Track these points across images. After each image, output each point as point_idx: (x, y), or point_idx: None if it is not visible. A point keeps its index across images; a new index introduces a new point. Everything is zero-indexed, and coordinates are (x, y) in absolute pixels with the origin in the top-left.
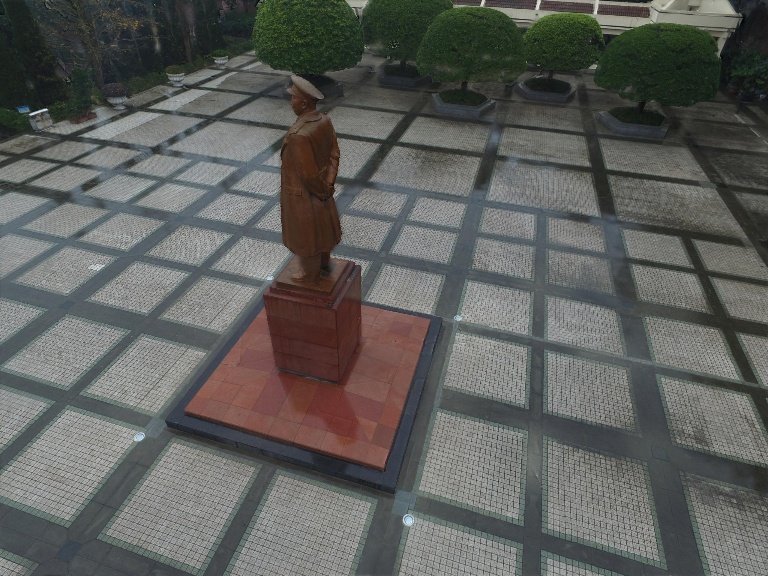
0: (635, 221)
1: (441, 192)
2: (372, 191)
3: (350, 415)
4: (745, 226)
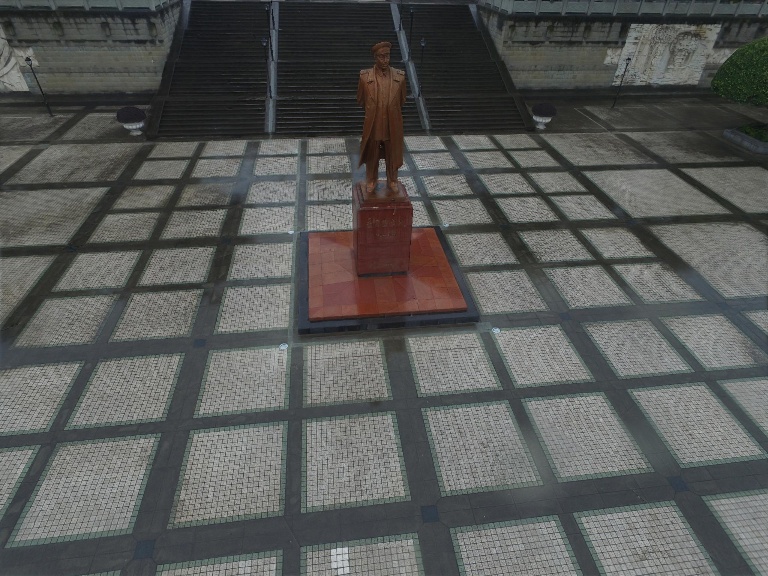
0: (117, 175)
1: (39, 276)
2: (27, 335)
3: (415, 241)
4: (124, 142)
